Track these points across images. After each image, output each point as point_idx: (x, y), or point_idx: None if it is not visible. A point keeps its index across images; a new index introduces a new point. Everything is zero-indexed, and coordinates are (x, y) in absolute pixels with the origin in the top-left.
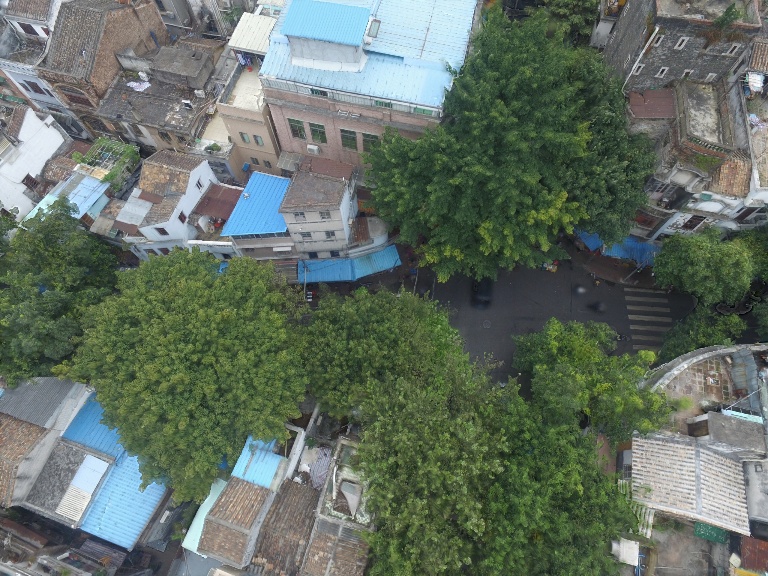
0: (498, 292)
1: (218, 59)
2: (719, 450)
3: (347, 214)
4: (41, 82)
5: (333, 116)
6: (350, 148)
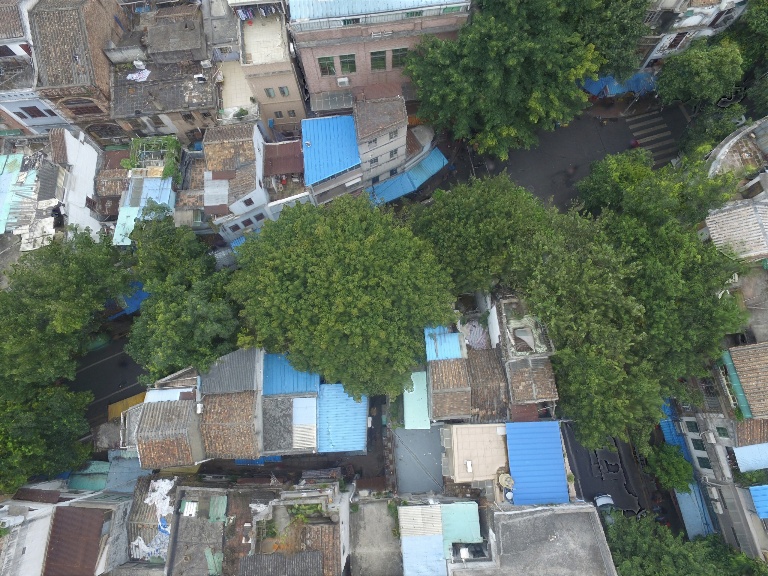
0: (529, 159)
1: (202, 24)
2: (767, 202)
3: None
4: (43, 103)
5: (367, 41)
6: (378, 69)
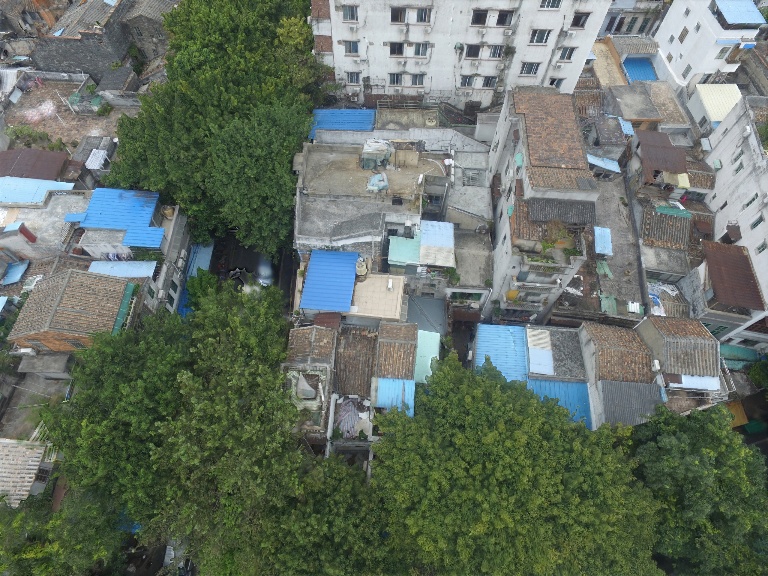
0: None
1: None
2: None
3: None
4: None
5: None
6: None
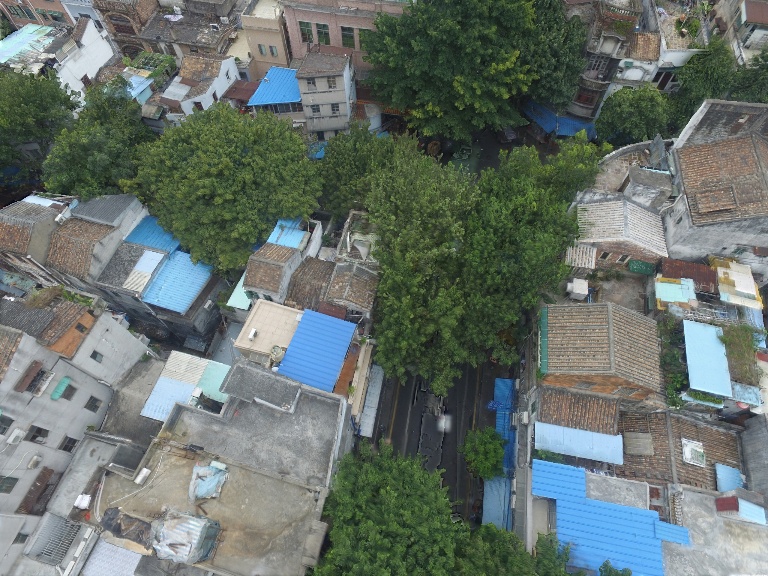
0: None
1: None
2: (642, 203)
3: (348, 92)
4: (94, 12)
5: (336, 12)
6: (349, 47)
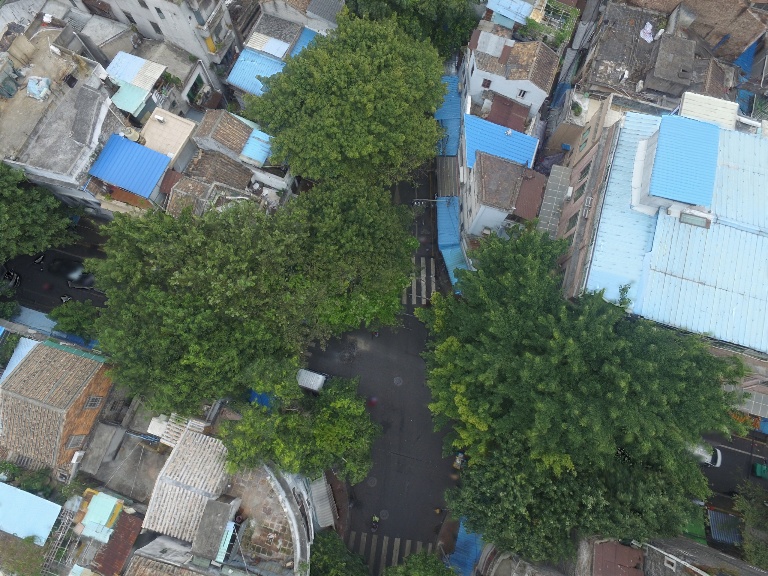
0: None
1: None
2: None
3: (490, 225)
4: None
5: (587, 194)
6: (568, 227)
